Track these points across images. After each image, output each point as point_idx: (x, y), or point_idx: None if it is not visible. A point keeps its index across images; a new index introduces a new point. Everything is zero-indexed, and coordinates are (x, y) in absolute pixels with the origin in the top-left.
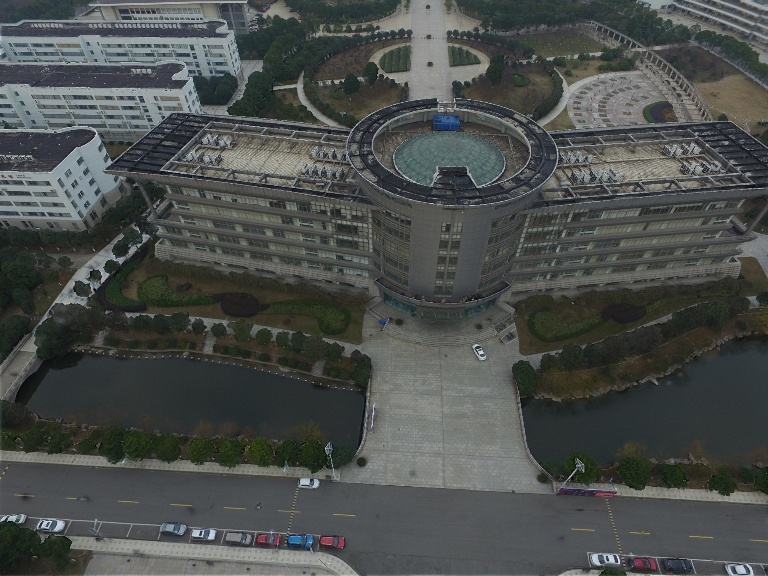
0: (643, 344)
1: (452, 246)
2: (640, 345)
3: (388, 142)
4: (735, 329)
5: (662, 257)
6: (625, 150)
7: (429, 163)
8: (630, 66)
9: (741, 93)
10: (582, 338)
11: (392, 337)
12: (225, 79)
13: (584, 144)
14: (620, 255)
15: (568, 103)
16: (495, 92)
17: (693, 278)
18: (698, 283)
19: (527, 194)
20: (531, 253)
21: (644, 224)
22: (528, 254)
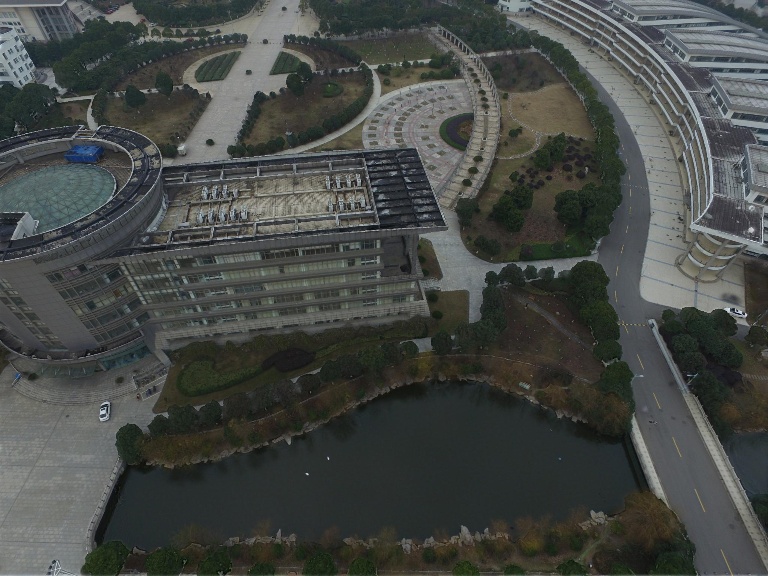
0: (261, 402)
1: (19, 302)
2: (258, 404)
3: (5, 177)
4: (407, 375)
5: (326, 299)
6: (290, 182)
7: (2, 206)
8: (454, 74)
9: (553, 104)
10: (230, 391)
11: (20, 394)
12: (1, 91)
13: (247, 175)
14: (275, 298)
15: (369, 115)
16: (298, 103)
17: (382, 317)
18: (386, 323)
19: (61, 247)
20: (161, 300)
21: (277, 267)
22: (158, 301)
